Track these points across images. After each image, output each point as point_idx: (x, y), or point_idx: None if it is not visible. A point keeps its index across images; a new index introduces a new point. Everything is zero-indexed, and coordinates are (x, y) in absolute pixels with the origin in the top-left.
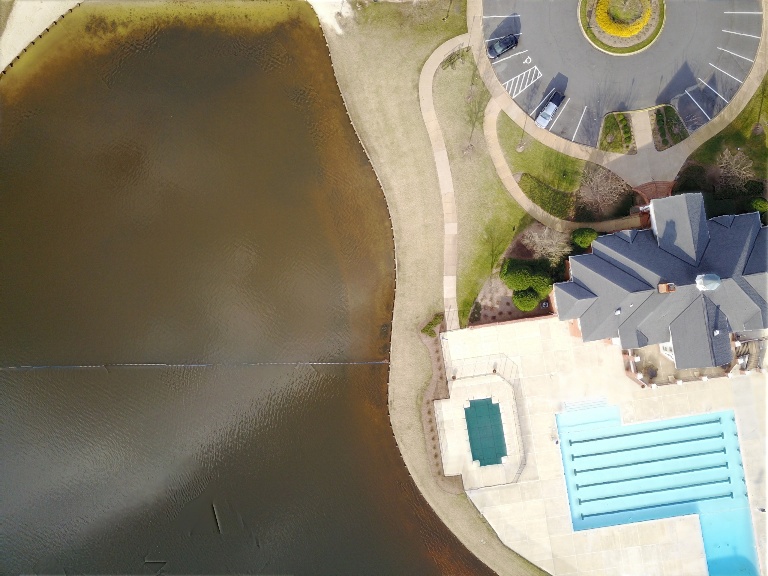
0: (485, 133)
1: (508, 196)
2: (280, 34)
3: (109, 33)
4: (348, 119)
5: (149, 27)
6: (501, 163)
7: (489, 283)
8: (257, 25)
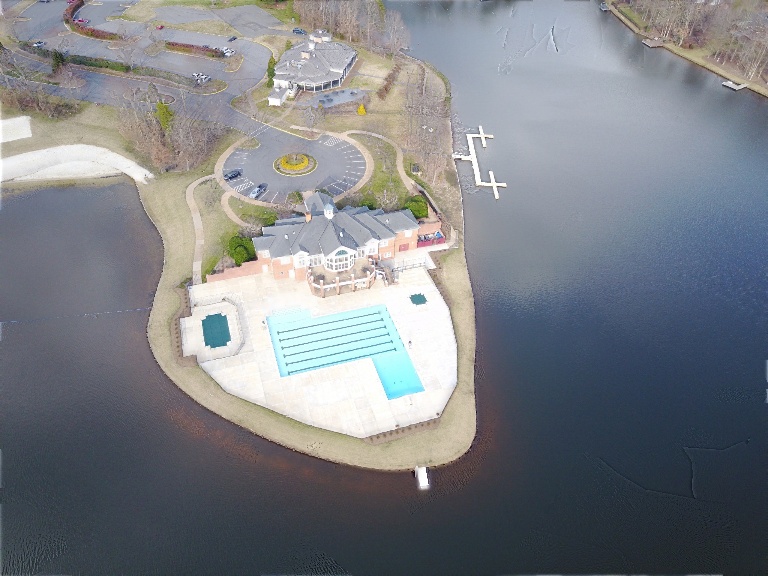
0: (222, 204)
1: (233, 223)
2: (112, 188)
3: (8, 193)
4: None
5: (34, 190)
6: (230, 213)
7: (222, 260)
8: (99, 186)
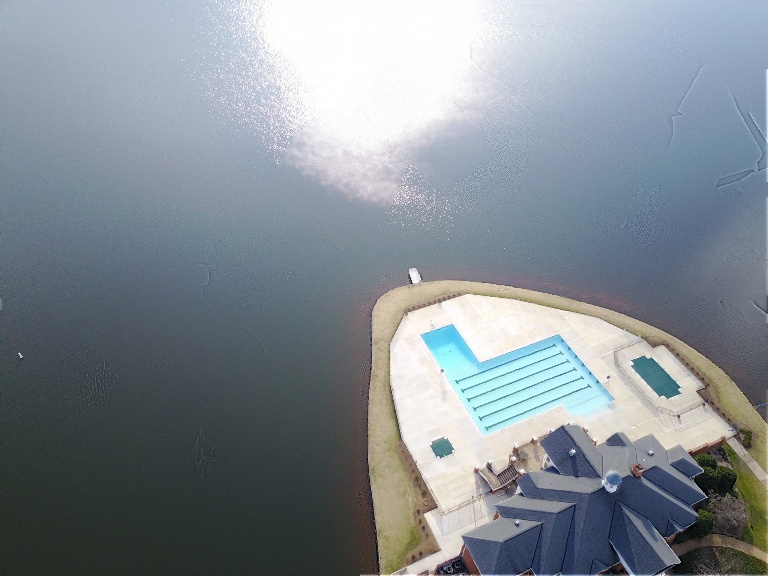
0: None
1: None
2: None
3: None
4: None
5: None
6: None
7: None
8: None
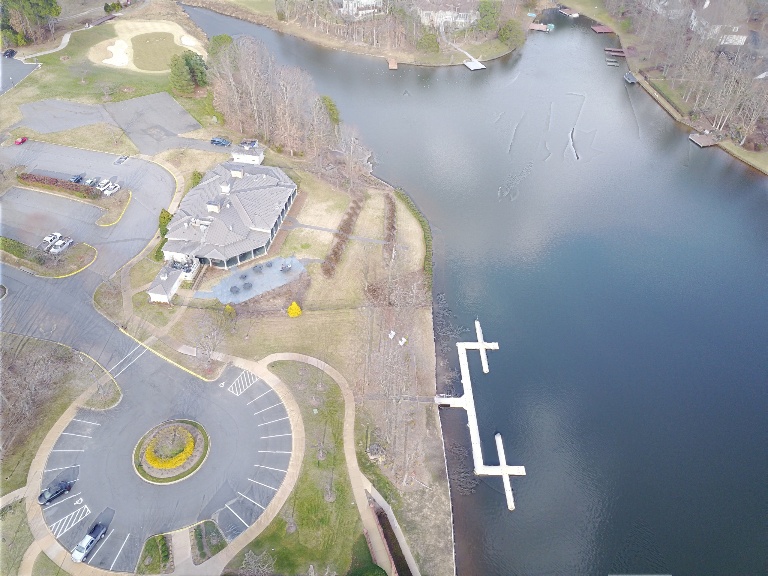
0: None
1: None
2: None
3: None
4: None
5: None
6: None
7: None
8: None
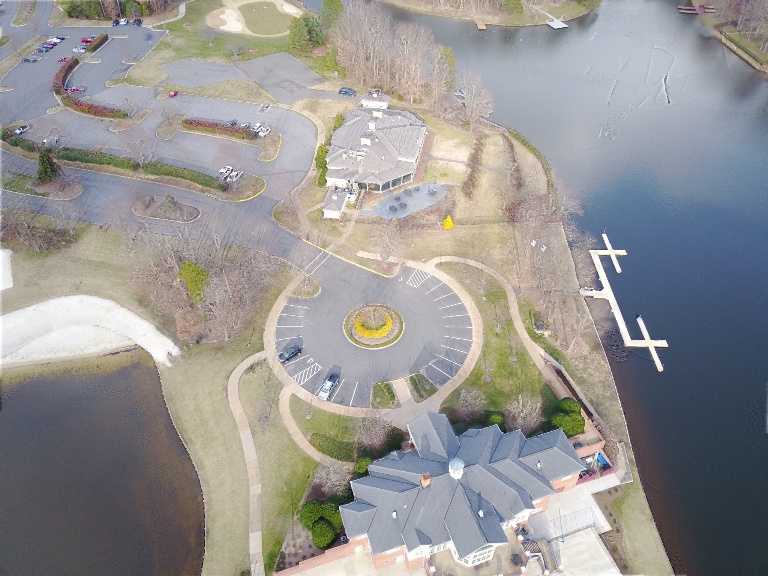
0: (280, 411)
1: (302, 452)
2: (123, 374)
3: None
4: (171, 422)
5: (16, 383)
6: (294, 429)
7: (291, 531)
8: (105, 371)
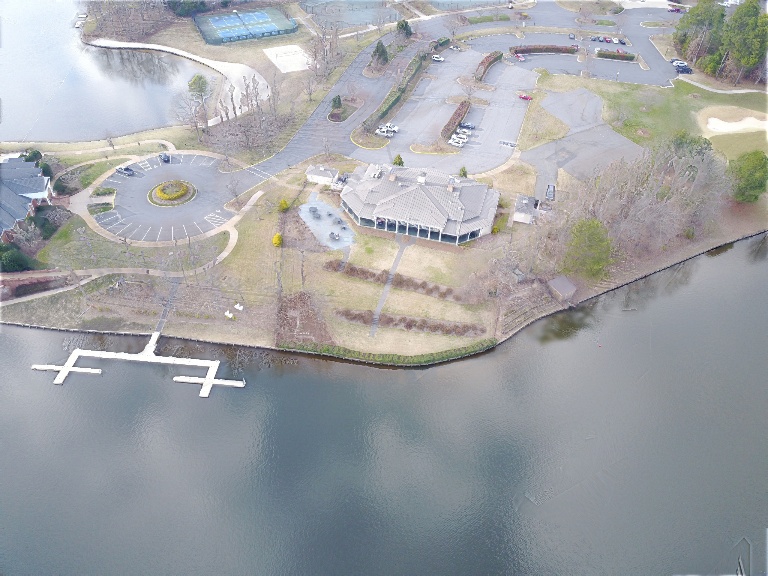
0: (122, 155)
1: (85, 161)
2: None
3: None
4: None
5: None
6: None
7: None
8: None
